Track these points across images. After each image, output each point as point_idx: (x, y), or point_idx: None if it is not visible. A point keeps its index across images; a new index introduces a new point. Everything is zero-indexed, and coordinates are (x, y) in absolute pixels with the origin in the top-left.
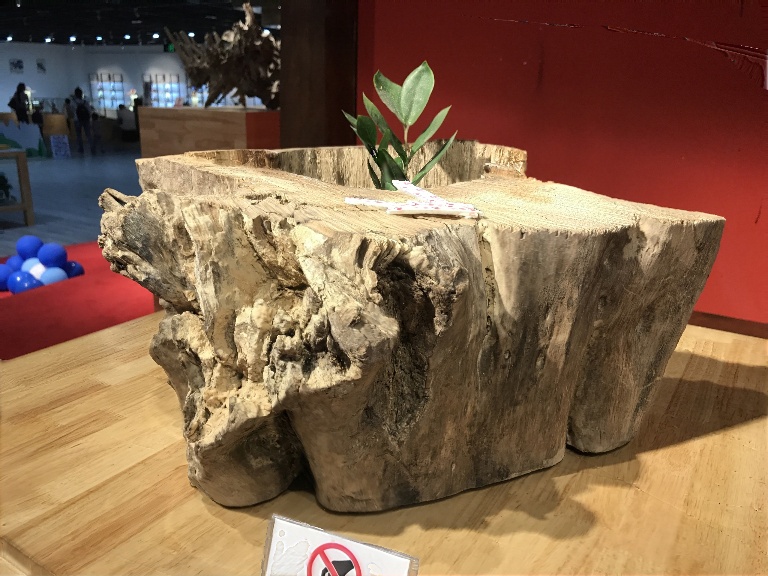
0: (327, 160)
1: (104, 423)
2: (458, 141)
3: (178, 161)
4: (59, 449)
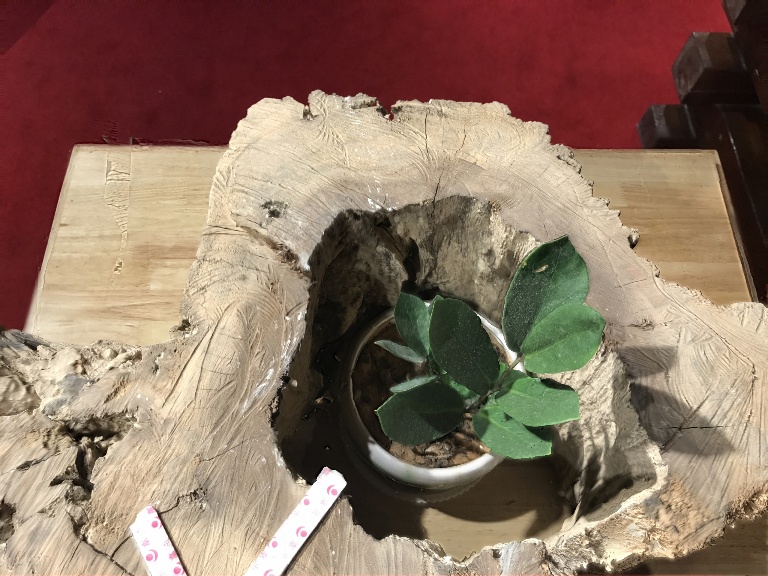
0: (499, 231)
1: (168, 313)
2: (638, 413)
3: (211, 197)
4: (119, 320)
